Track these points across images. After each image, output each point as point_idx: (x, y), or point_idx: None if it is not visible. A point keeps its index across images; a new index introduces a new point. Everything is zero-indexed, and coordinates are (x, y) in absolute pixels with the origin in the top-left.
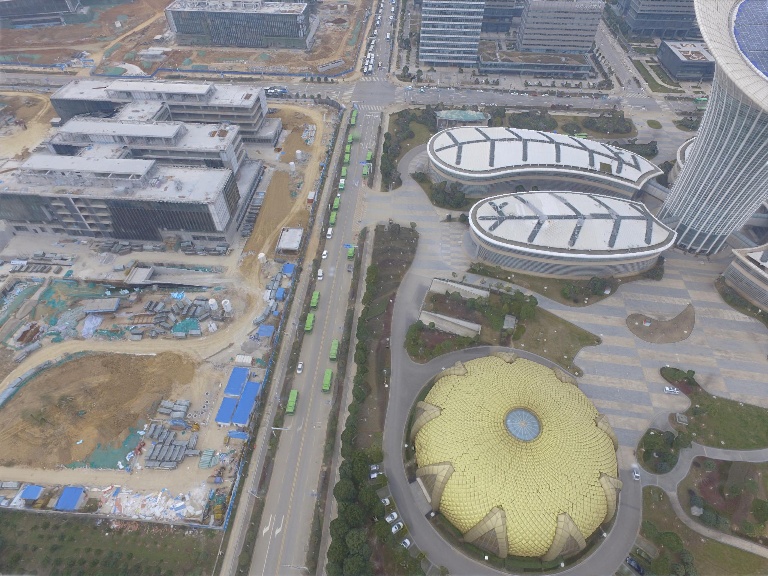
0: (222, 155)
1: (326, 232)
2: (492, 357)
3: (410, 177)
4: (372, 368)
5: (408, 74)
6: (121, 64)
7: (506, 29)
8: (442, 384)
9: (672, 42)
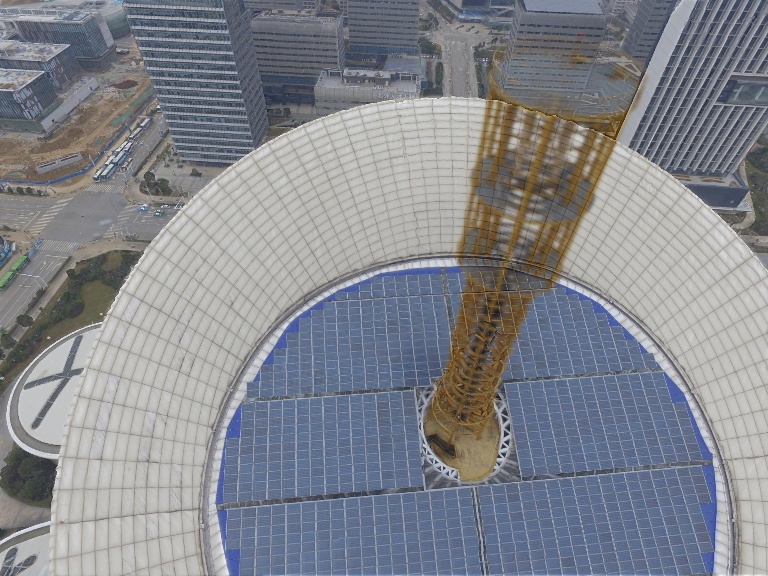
0: None
1: None
2: None
3: None
4: None
5: (158, 180)
6: None
7: None
8: None
9: None
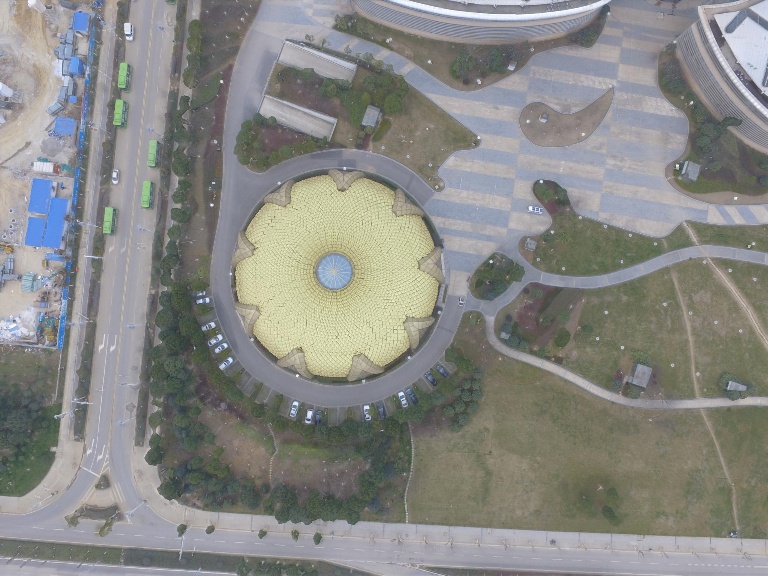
0: None
1: None
2: (326, 180)
3: None
4: (199, 179)
5: None
6: None
7: None
8: (261, 215)
9: None
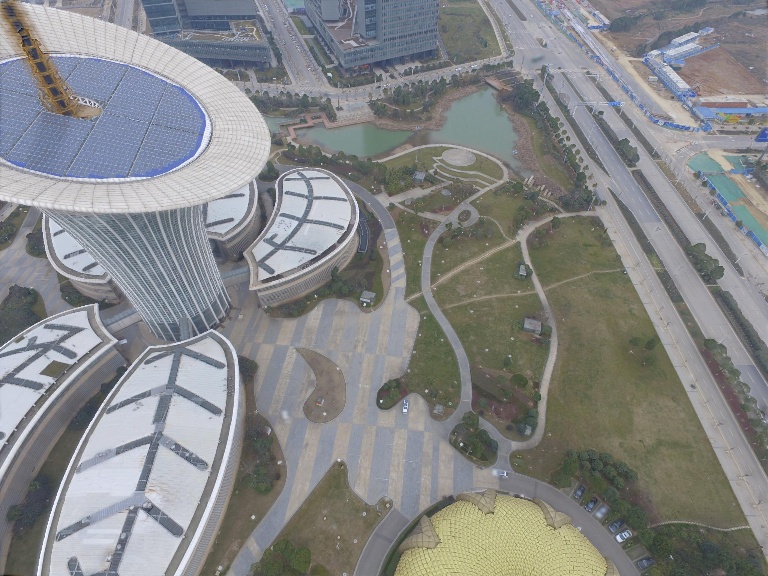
0: None
1: None
2: None
3: None
4: None
5: None
6: None
7: None
8: None
9: None
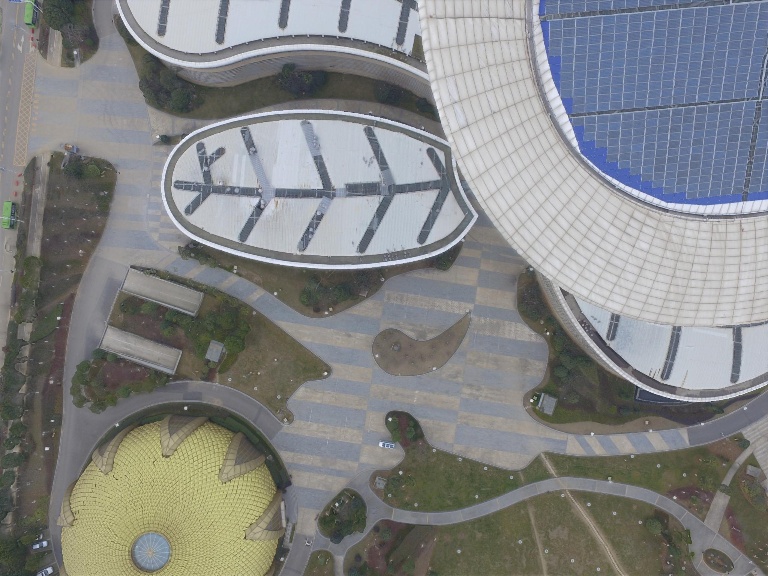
0: None
1: None
2: (152, 440)
3: (114, 26)
4: (37, 416)
5: None
6: None
7: None
8: (84, 480)
9: None
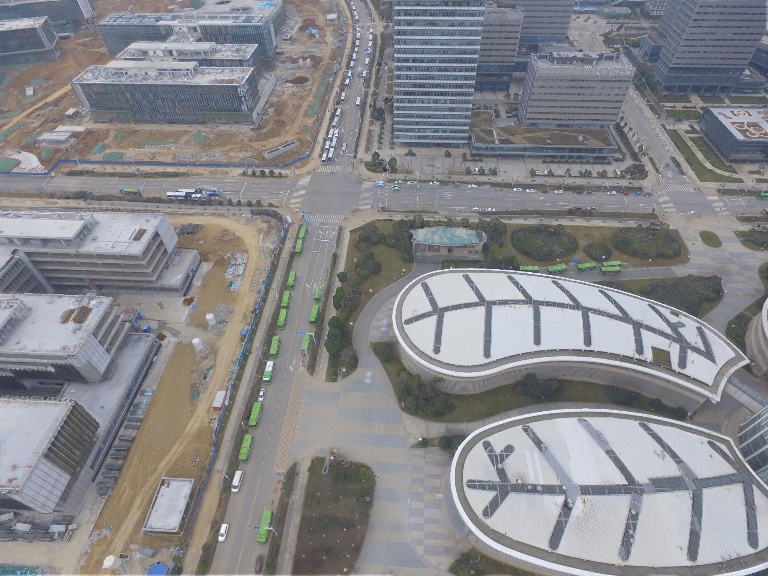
0: (71, 361)
1: (232, 478)
2: None
3: (370, 350)
4: None
5: (379, 160)
6: (15, 153)
7: (505, 87)
8: None
9: (719, 108)
